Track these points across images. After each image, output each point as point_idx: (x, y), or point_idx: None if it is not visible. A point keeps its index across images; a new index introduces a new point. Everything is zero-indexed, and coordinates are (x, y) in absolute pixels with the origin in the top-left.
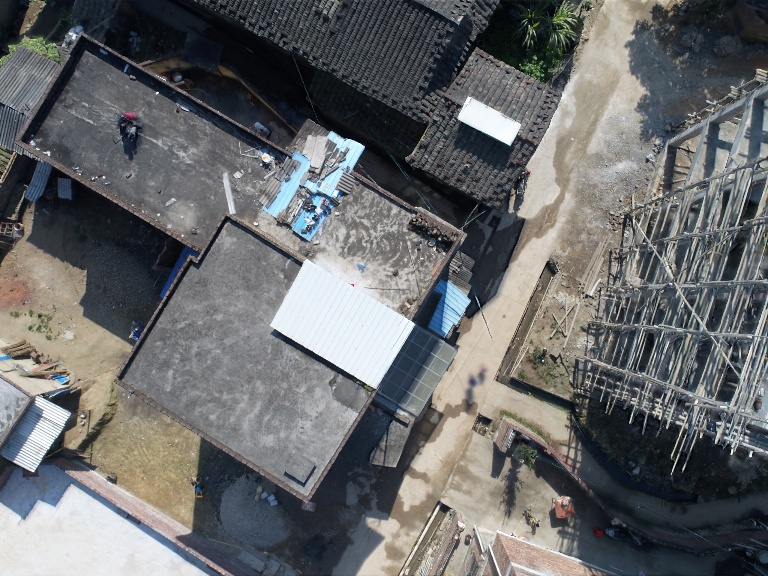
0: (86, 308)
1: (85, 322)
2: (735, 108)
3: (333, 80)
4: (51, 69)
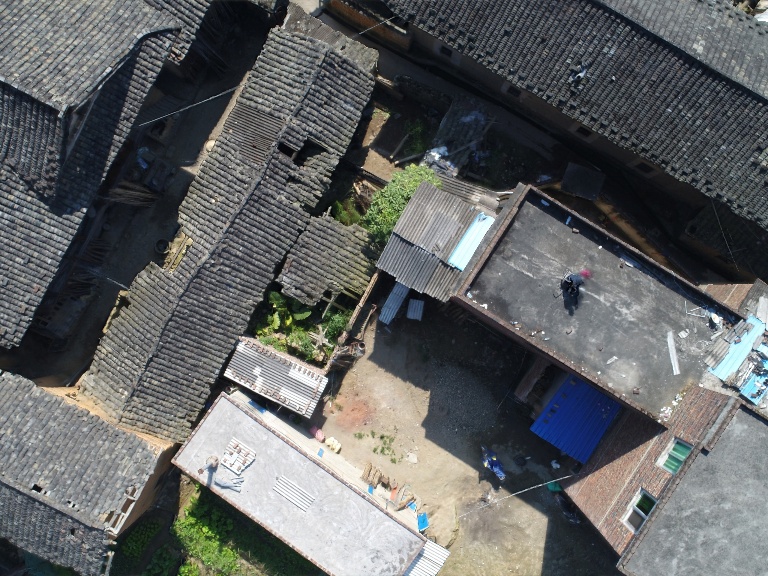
0: (428, 430)
1: (427, 444)
2: None
3: (724, 217)
4: (457, 207)
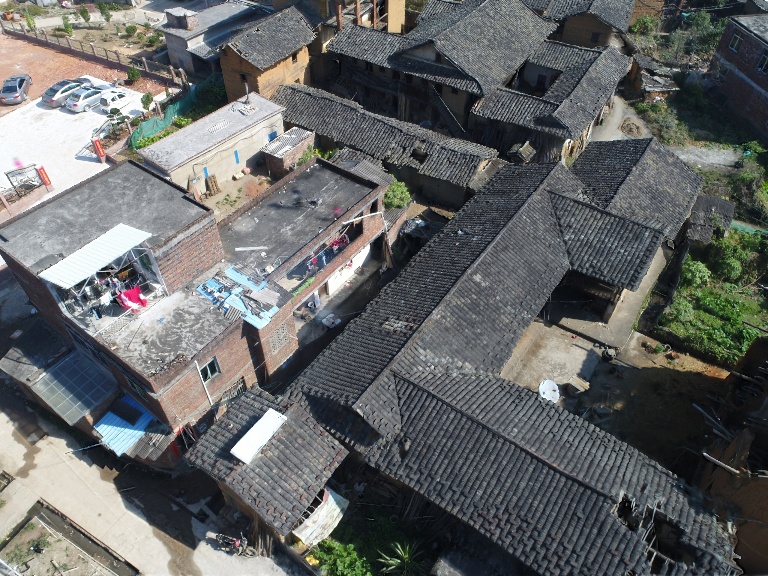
0: None
1: None
2: None
3: None
4: None
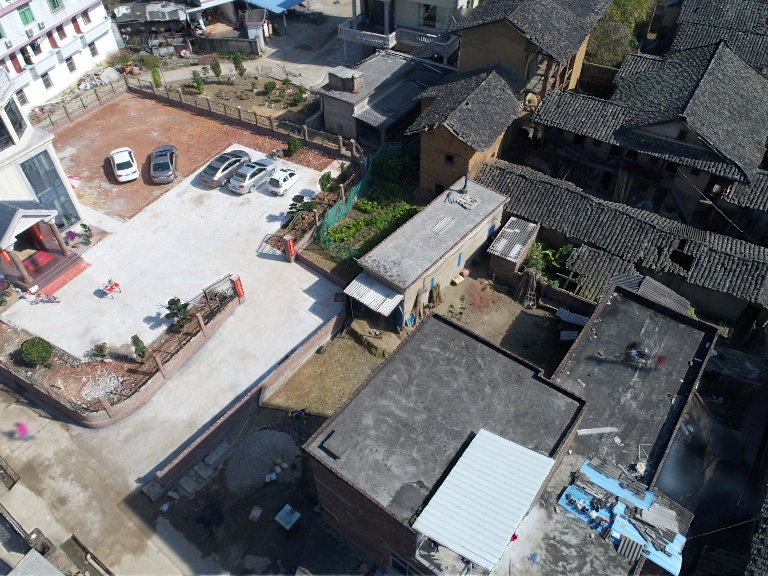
0: None
1: None
2: None
3: (739, 575)
4: None
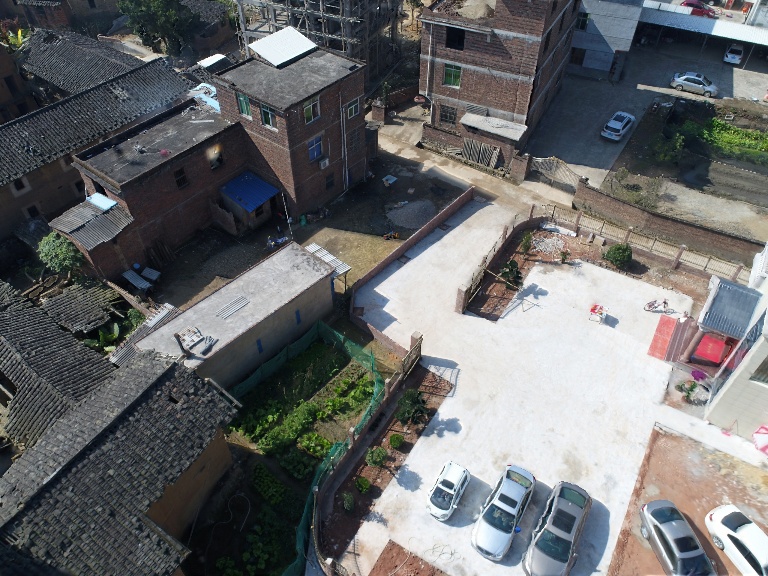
0: None
1: None
2: (241, 11)
3: None
4: None
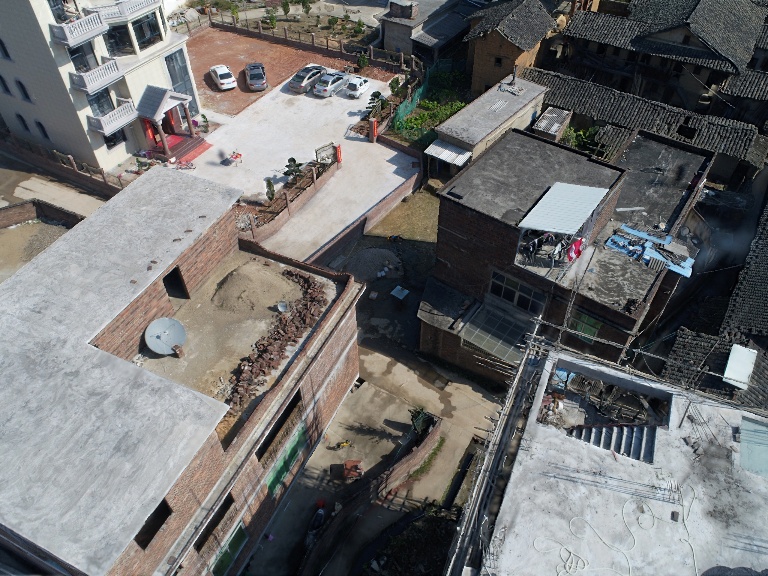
0: None
1: None
2: None
3: None
4: None
